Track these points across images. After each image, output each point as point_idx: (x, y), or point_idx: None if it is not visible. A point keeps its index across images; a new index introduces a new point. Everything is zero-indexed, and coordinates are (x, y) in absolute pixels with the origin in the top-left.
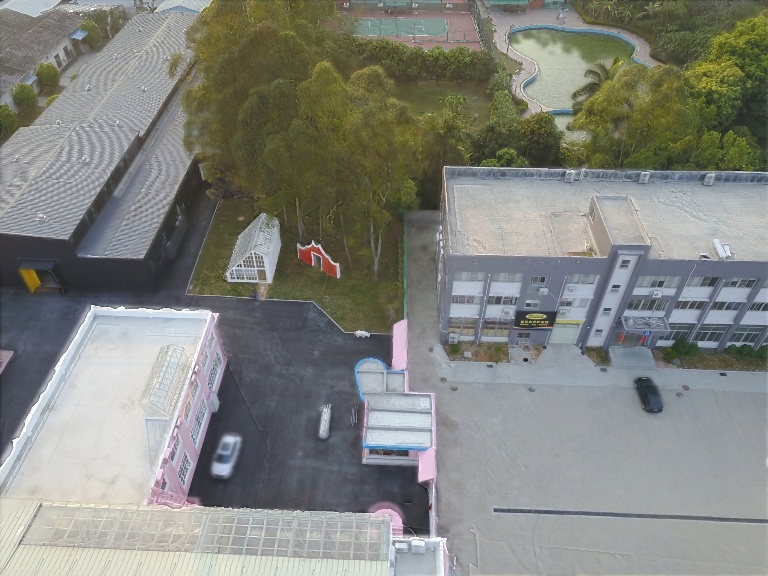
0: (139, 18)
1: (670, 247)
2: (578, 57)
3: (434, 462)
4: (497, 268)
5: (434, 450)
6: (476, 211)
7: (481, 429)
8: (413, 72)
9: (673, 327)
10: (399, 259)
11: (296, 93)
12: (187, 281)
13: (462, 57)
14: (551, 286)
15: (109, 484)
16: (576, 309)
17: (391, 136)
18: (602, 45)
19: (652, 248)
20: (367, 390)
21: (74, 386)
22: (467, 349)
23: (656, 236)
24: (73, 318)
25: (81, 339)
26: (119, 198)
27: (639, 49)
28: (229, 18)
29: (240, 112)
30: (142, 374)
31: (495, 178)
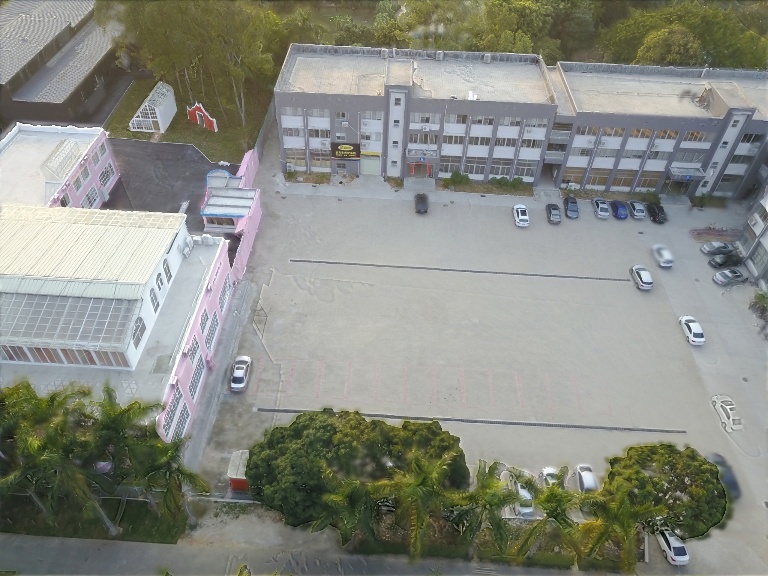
0: None
1: (438, 96)
2: None
3: (246, 221)
4: (309, 104)
5: (248, 216)
6: (307, 72)
7: (296, 219)
8: None
9: (447, 160)
10: None
11: None
12: None
13: None
14: (350, 120)
15: None
16: (374, 142)
17: (229, 2)
18: None
19: (424, 96)
20: (212, 186)
21: None
22: (300, 176)
23: (431, 89)
24: None
25: (7, 142)
26: (50, 68)
27: None
28: None
29: None
30: None
31: (330, 54)
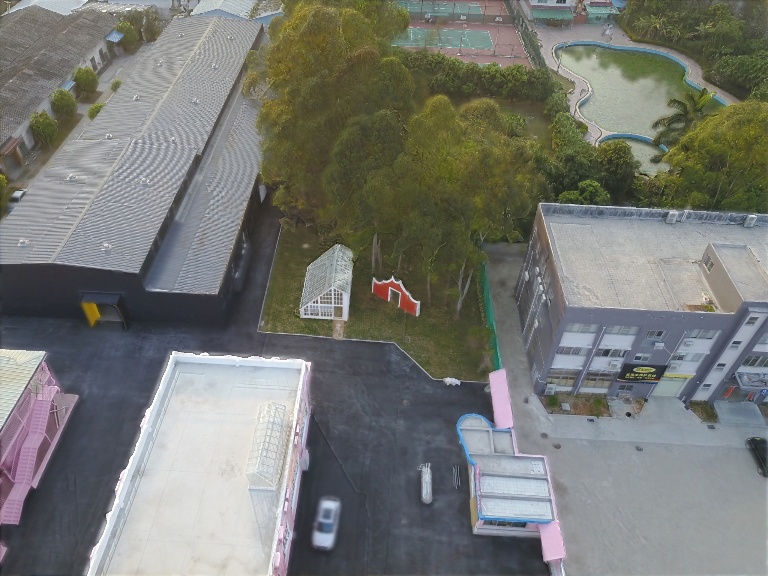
0: (179, 21)
1: None
2: (629, 77)
3: (561, 539)
4: (614, 321)
5: (558, 524)
6: (580, 254)
7: (592, 493)
8: (468, 89)
9: None
10: (479, 296)
11: (399, 124)
12: (258, 317)
13: (520, 75)
14: (668, 340)
15: (219, 569)
16: (687, 363)
17: (511, 178)
18: (651, 65)
19: None
20: (474, 451)
21: (164, 447)
22: (564, 400)
23: None
24: (139, 357)
25: (164, 390)
26: (182, 223)
27: (690, 71)
28: (321, 38)
29: (338, 143)
30: (238, 434)
31: (592, 216)
